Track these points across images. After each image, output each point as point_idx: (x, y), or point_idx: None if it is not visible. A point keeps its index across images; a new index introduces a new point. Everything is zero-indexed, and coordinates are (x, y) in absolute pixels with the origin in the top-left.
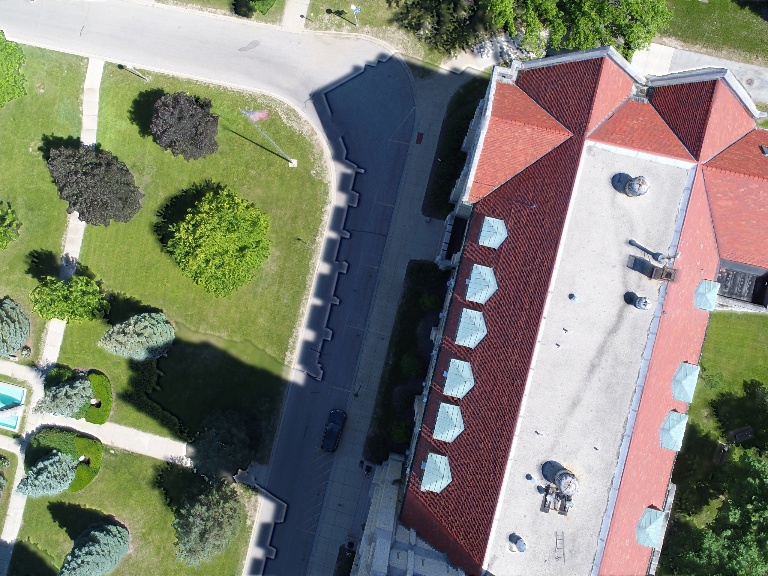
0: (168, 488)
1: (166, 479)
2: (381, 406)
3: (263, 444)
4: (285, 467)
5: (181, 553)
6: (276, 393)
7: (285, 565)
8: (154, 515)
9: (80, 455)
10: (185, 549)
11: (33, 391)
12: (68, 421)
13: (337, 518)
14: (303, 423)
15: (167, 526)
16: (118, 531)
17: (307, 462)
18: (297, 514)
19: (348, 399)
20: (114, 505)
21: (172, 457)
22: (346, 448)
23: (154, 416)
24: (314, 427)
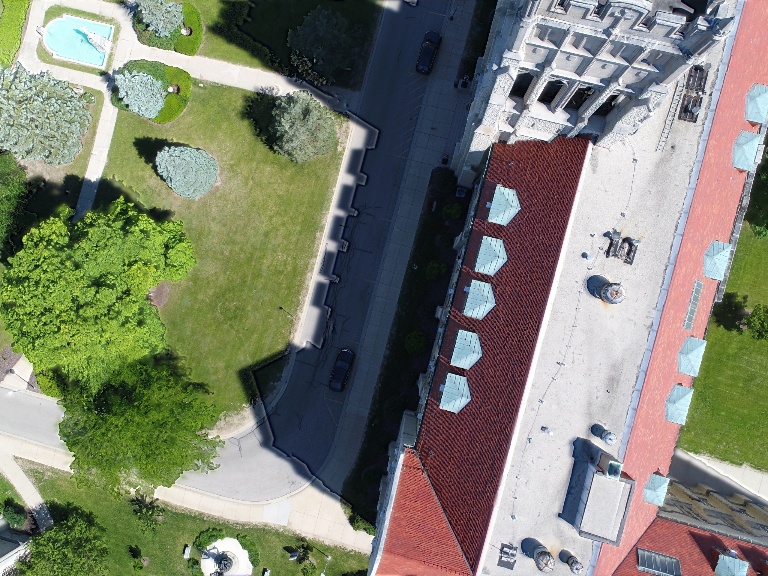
0: (258, 119)
1: (256, 110)
2: (476, 28)
3: (356, 70)
4: (377, 93)
5: (286, 121)
6: (370, 19)
7: (376, 191)
8: (243, 146)
9: (169, 84)
10: (290, 119)
11: (121, 28)
12: (156, 56)
13: (430, 141)
14: (397, 49)
15: (256, 157)
16: (207, 157)
17: (400, 87)
18: (389, 140)
19: (443, 23)
20: (202, 138)
21: (262, 88)
22: (440, 72)
23: (245, 47)
24: (408, 52)
